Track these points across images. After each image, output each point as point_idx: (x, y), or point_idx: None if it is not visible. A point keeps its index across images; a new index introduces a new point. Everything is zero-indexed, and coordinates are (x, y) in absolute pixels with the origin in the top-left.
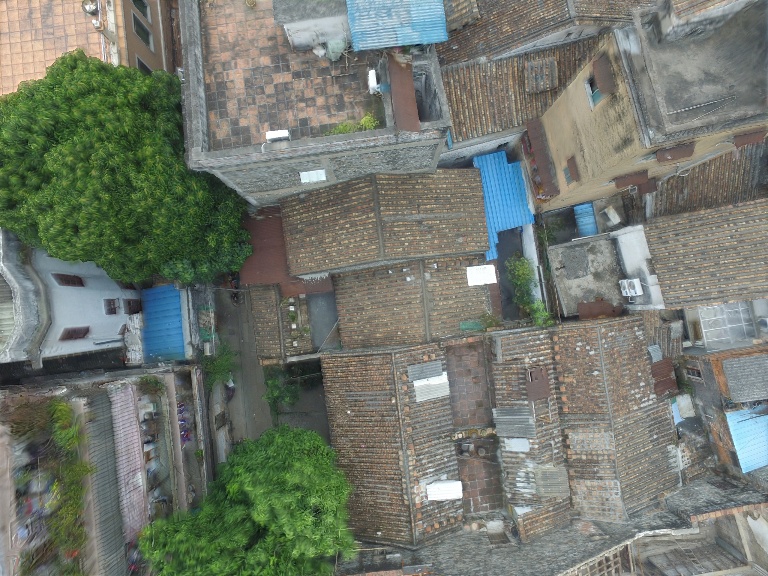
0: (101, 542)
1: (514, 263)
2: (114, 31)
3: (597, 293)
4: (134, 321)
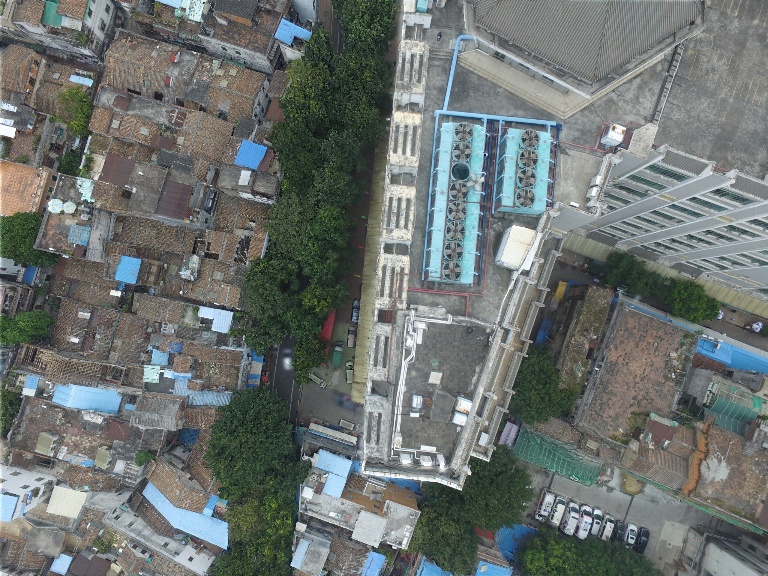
0: None
1: (129, 293)
2: (37, 203)
3: None
4: (23, 270)
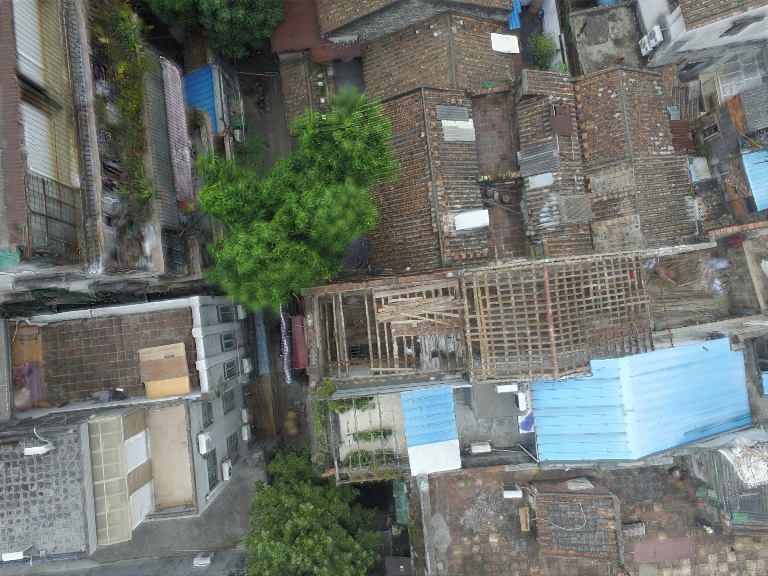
0: (157, 176)
1: (536, 38)
2: None
3: (617, 58)
4: None
